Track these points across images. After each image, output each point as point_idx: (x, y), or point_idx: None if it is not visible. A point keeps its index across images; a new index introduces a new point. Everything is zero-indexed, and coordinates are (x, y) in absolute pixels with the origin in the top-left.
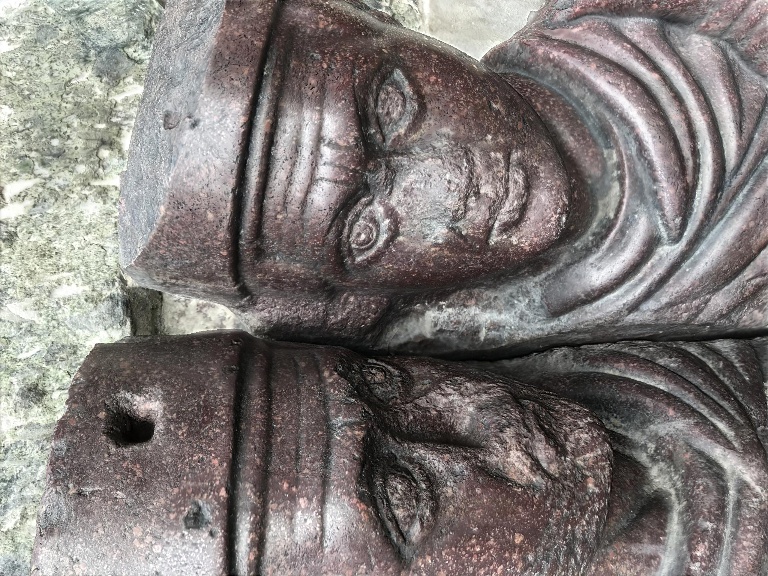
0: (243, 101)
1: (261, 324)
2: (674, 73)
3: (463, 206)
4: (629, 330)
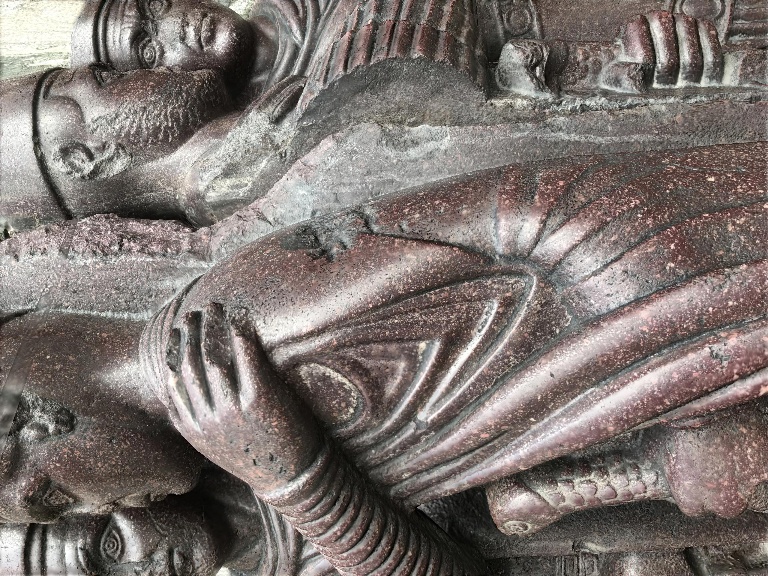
0: (96, 7)
1: None
2: None
3: (182, 30)
4: None
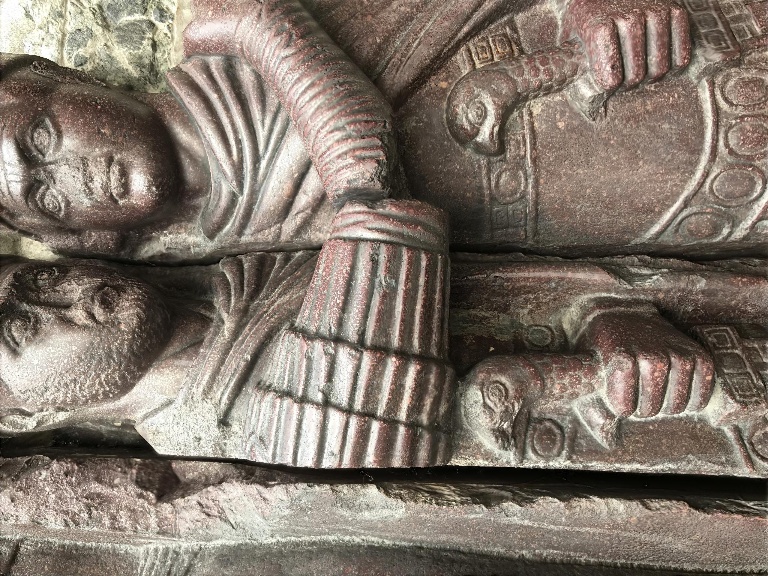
0: None
1: (51, 249)
2: (225, 92)
3: (86, 188)
4: (253, 246)
